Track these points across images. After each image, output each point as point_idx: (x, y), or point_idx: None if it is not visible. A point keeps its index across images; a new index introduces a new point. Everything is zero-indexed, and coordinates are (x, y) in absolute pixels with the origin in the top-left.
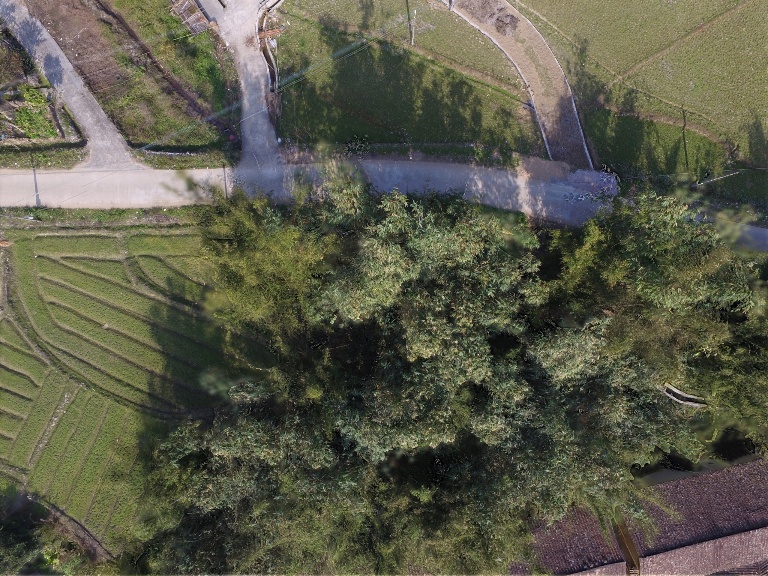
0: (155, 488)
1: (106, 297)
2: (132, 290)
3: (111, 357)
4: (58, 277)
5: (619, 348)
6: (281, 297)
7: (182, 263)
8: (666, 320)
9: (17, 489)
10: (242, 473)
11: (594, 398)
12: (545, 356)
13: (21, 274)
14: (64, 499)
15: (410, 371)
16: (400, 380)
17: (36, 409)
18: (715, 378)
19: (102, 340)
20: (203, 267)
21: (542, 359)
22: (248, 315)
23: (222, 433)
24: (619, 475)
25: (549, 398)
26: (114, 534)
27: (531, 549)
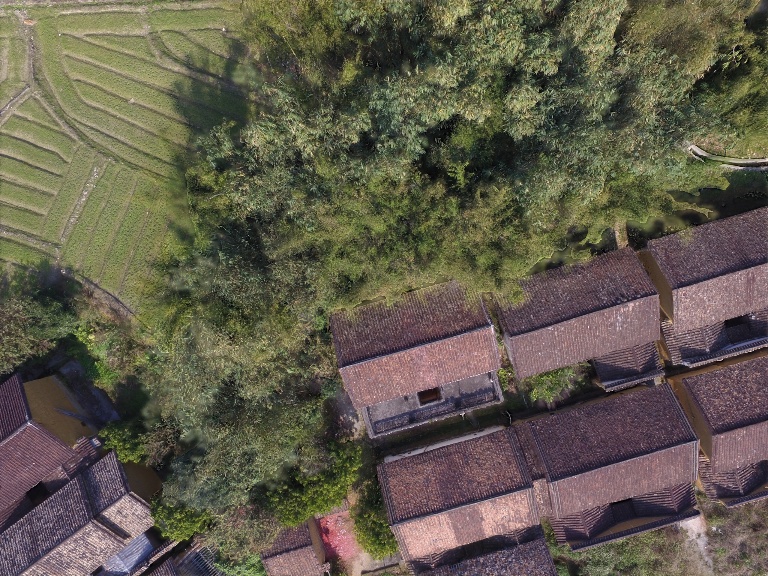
0: (192, 192)
1: (131, 72)
2: (156, 64)
3: (138, 131)
4: (83, 53)
5: (652, 11)
6: (310, 8)
7: (205, 36)
8: (697, 1)
9: (51, 263)
10: (279, 164)
11: (626, 95)
12: (578, 22)
13: (46, 52)
14: (97, 273)
15: (443, 54)
16: (433, 64)
17: (66, 184)
18: (746, 81)
19: (129, 114)
20: (226, 39)
21: (575, 25)
22: (278, 24)
23: (258, 116)
24: (654, 158)
25: (582, 81)
26: (148, 305)
27: (563, 292)
